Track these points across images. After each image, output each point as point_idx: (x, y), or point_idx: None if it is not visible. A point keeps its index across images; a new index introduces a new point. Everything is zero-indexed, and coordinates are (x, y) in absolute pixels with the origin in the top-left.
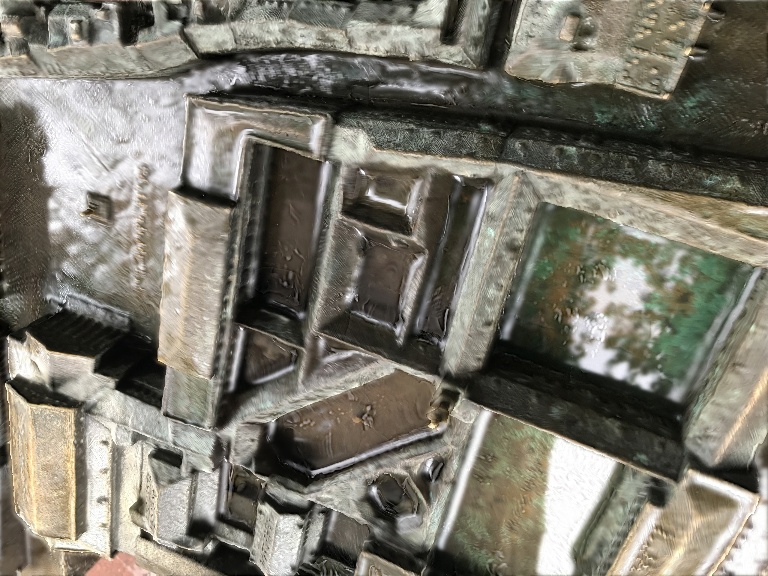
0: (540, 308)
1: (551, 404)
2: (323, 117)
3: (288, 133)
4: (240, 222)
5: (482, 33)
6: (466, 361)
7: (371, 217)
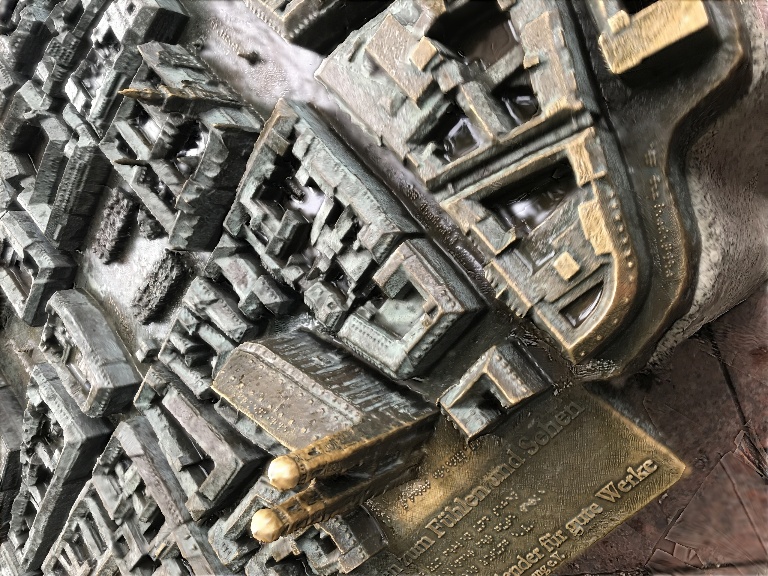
0: None
1: None
2: None
3: None
4: None
5: None
6: None
7: None
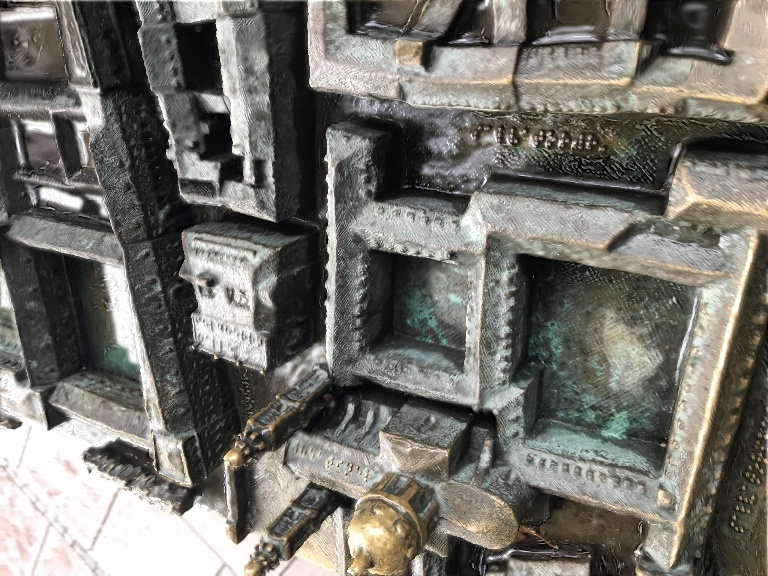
0: (105, 264)
1: (35, 300)
2: (93, 86)
3: (72, 52)
4: (3, 9)
5: (204, 204)
6: (21, 239)
7: (66, 138)
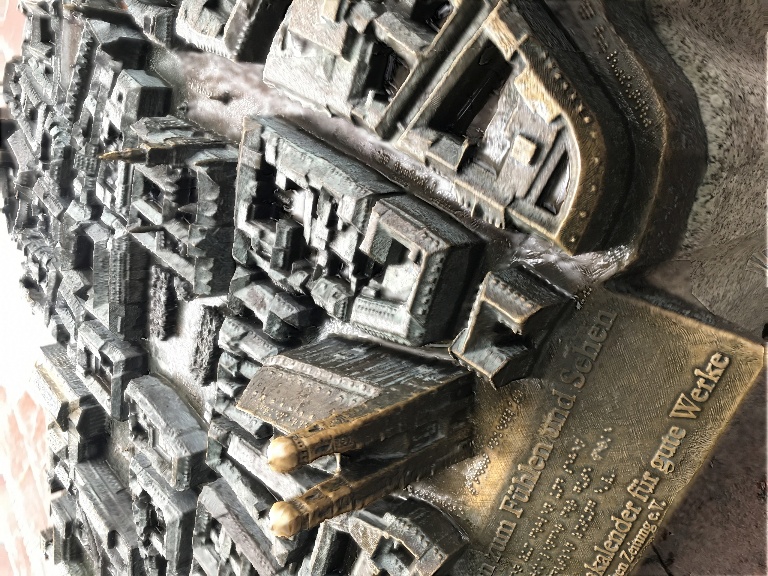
0: None
1: None
2: None
3: None
4: None
5: None
6: None
7: None
